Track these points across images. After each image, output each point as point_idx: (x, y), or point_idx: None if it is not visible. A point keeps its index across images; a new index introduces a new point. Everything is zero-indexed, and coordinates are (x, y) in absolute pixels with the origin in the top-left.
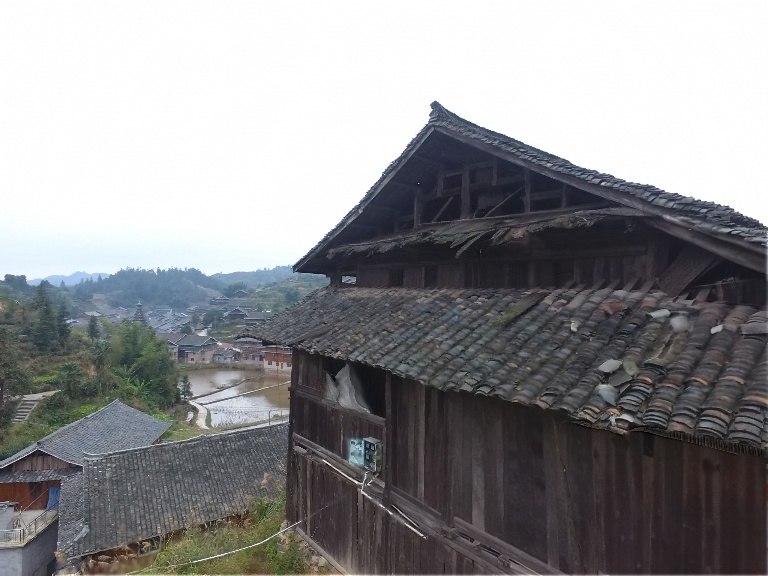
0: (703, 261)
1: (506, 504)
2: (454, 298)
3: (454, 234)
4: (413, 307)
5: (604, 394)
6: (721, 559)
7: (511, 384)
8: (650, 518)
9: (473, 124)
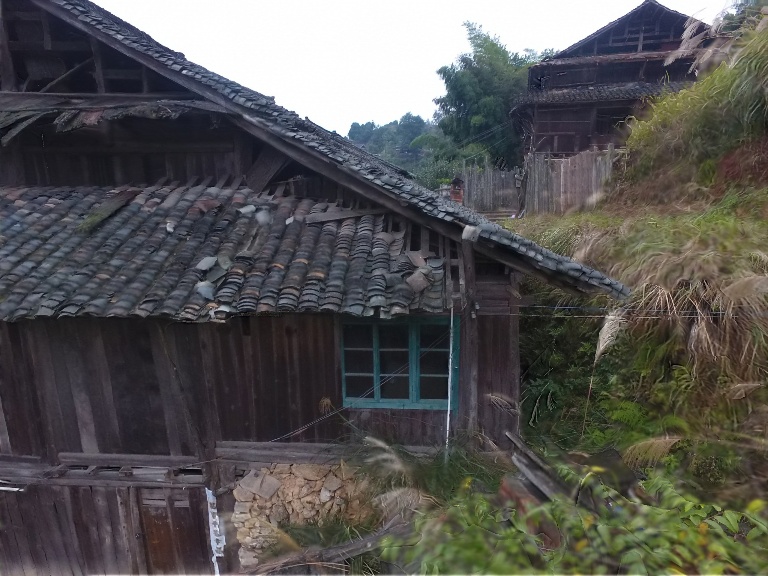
0: (278, 160)
1: (120, 418)
2: (11, 200)
3: None
4: None
5: (203, 291)
6: (301, 396)
7: (104, 298)
8: (252, 384)
9: None
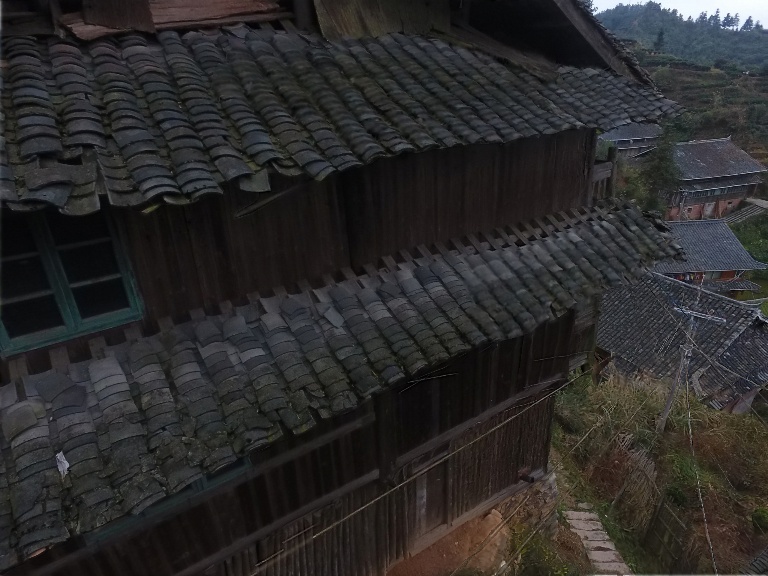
0: None
1: None
2: None
3: None
4: None
5: None
6: None
7: None
8: None
9: None
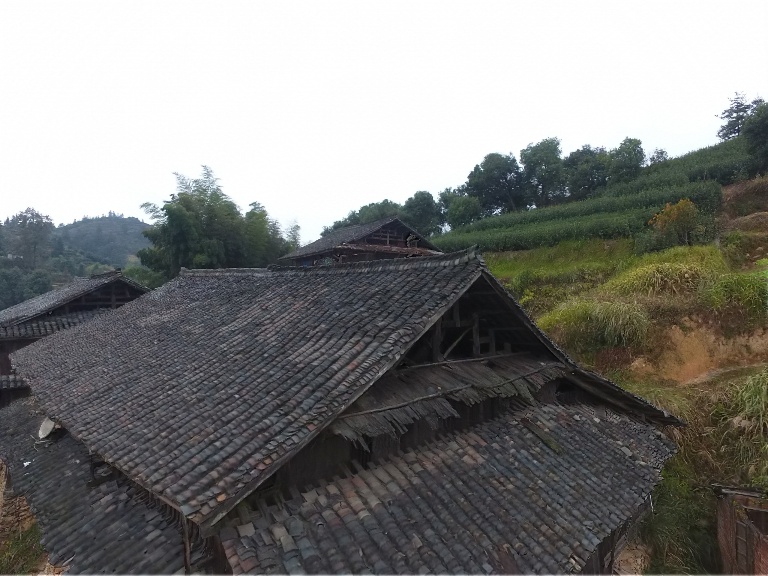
0: (553, 385)
1: None
2: None
3: (503, 384)
4: None
5: None
6: None
7: None
8: None
9: None
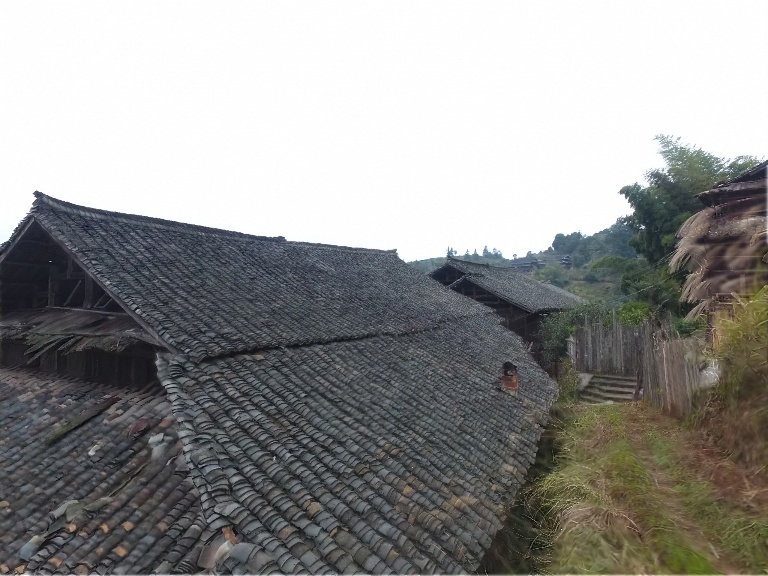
0: None
1: None
2: (52, 396)
3: (44, 334)
4: (7, 407)
5: (24, 550)
6: None
7: None
8: None
9: (97, 210)
